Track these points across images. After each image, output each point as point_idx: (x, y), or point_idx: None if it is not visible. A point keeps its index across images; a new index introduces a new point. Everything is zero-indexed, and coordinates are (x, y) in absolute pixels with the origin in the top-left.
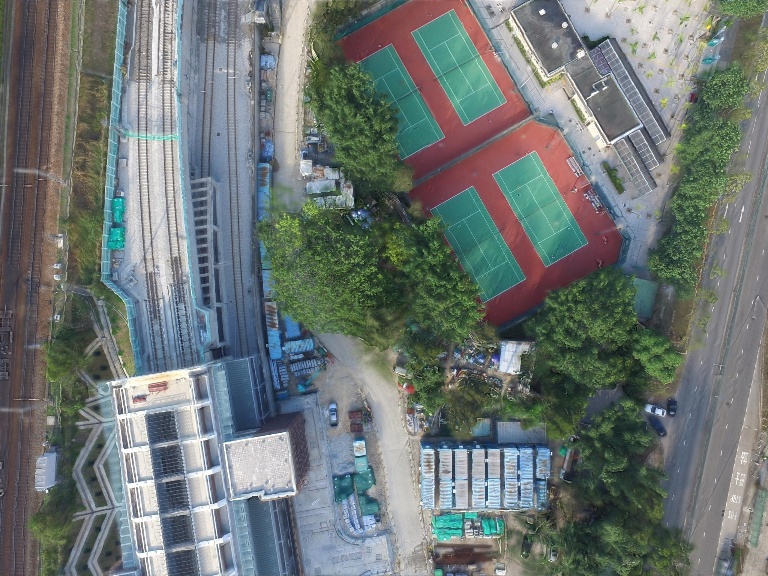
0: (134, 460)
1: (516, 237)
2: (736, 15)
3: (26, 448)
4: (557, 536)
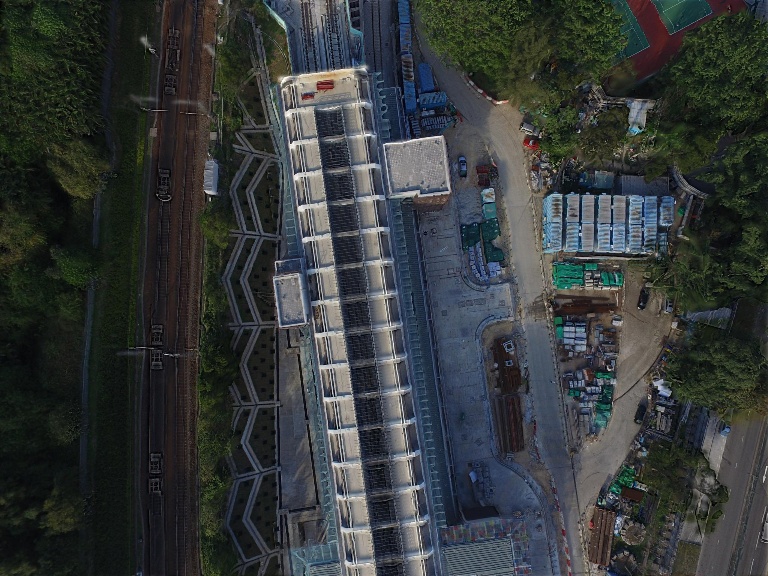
0: (303, 152)
1: (642, 4)
2: None
3: (191, 159)
4: None
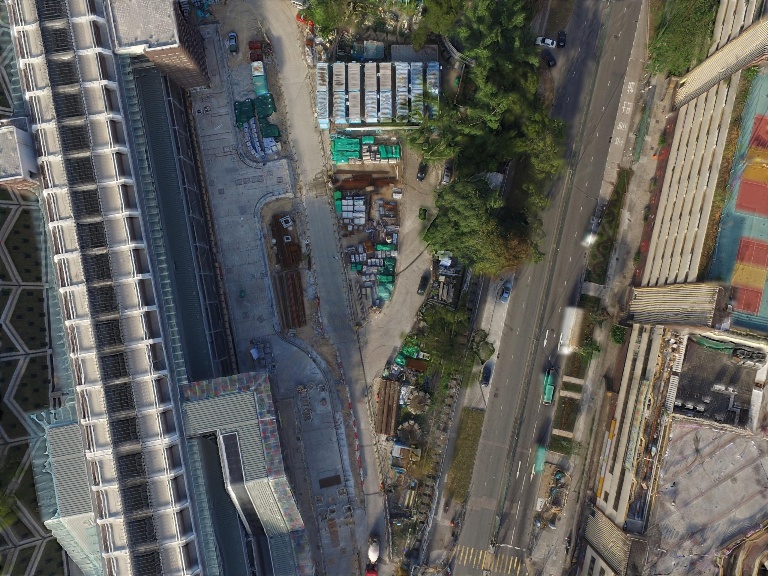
0: (20, 5)
1: None
2: None
3: None
4: (451, 161)
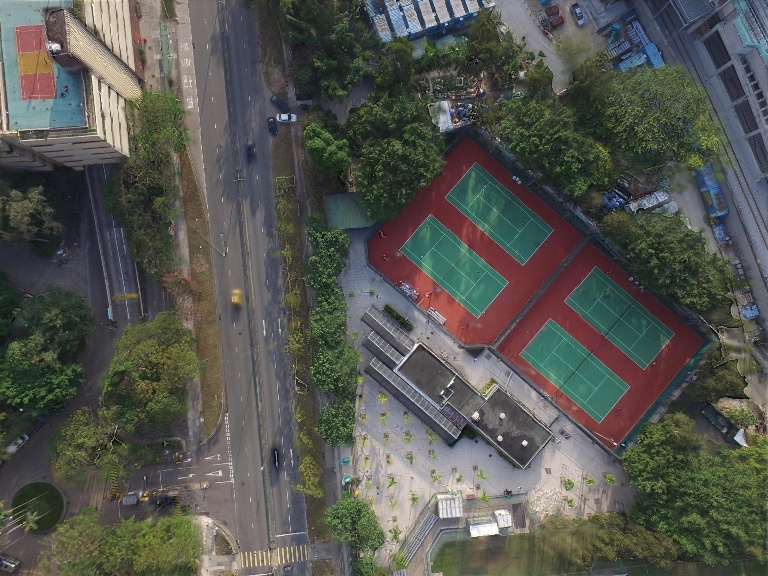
0: None
1: (468, 232)
2: (350, 501)
3: None
4: None
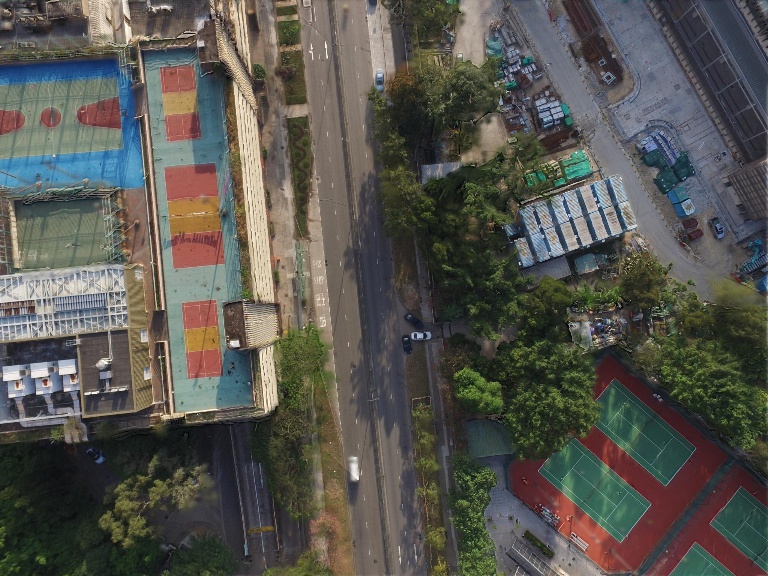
0: None
1: (609, 452)
2: None
3: None
4: None
